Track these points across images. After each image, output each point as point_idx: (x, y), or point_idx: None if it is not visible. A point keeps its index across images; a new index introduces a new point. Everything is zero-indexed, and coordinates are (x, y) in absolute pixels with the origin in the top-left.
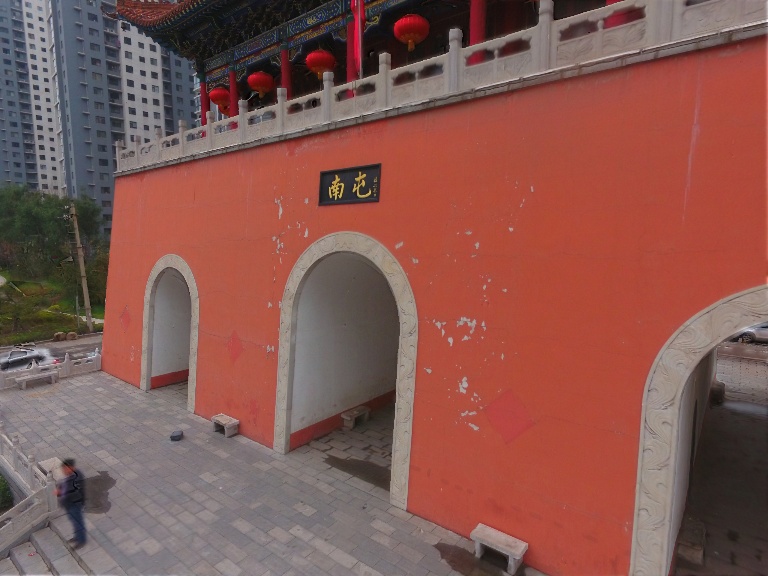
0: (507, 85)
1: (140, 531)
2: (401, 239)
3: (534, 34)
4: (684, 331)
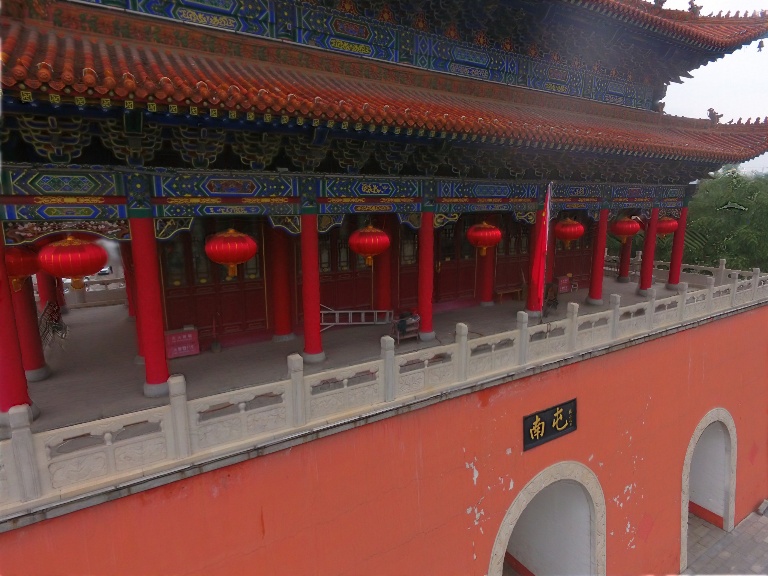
0: (644, 338)
1: None
2: (592, 452)
3: (648, 307)
4: None
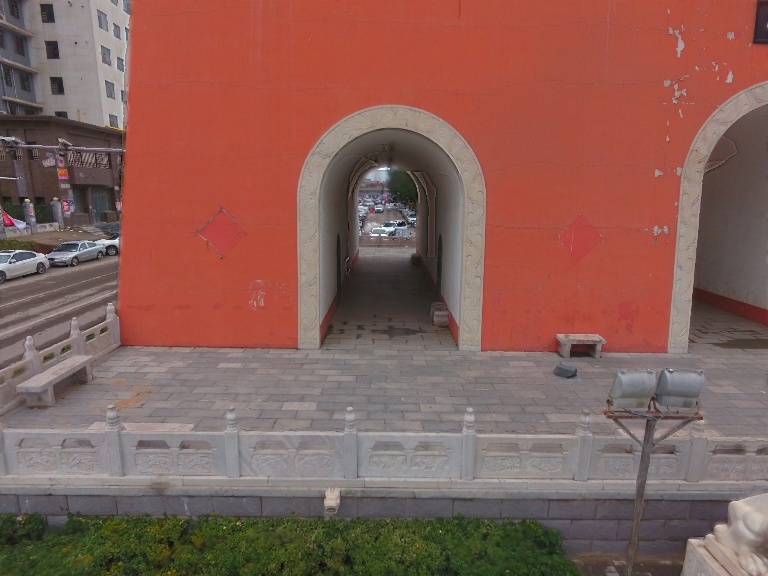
0: None
1: None
2: None
3: None
4: None
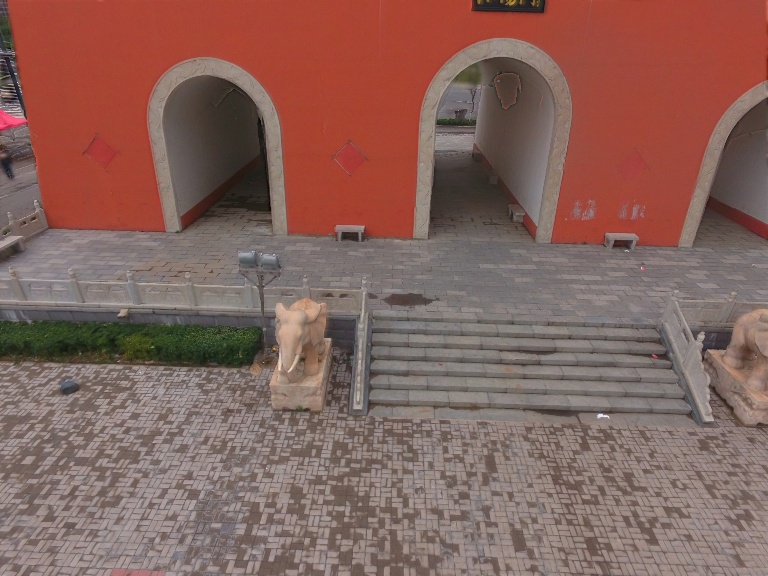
0: None
1: (461, 138)
2: None
3: None
4: None
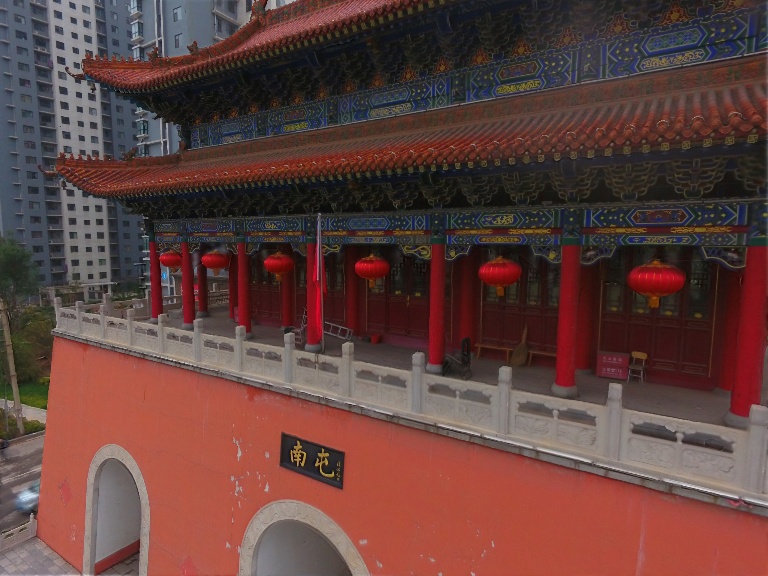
0: (469, 436)
1: None
2: (365, 536)
3: (494, 394)
4: None
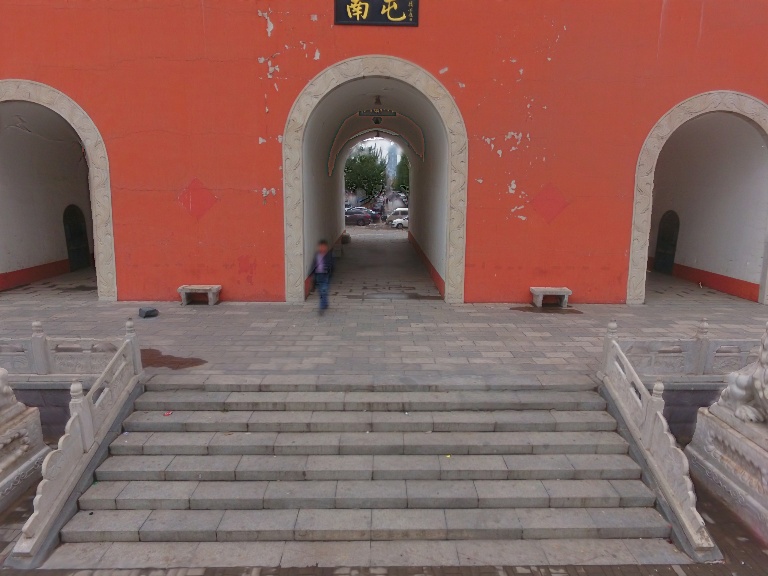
0: None
1: (284, 358)
2: (445, 65)
3: None
4: (658, 126)
